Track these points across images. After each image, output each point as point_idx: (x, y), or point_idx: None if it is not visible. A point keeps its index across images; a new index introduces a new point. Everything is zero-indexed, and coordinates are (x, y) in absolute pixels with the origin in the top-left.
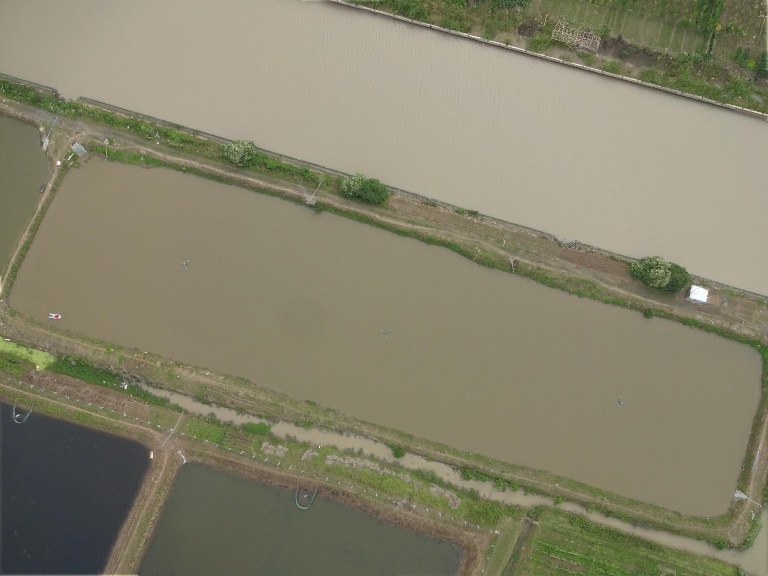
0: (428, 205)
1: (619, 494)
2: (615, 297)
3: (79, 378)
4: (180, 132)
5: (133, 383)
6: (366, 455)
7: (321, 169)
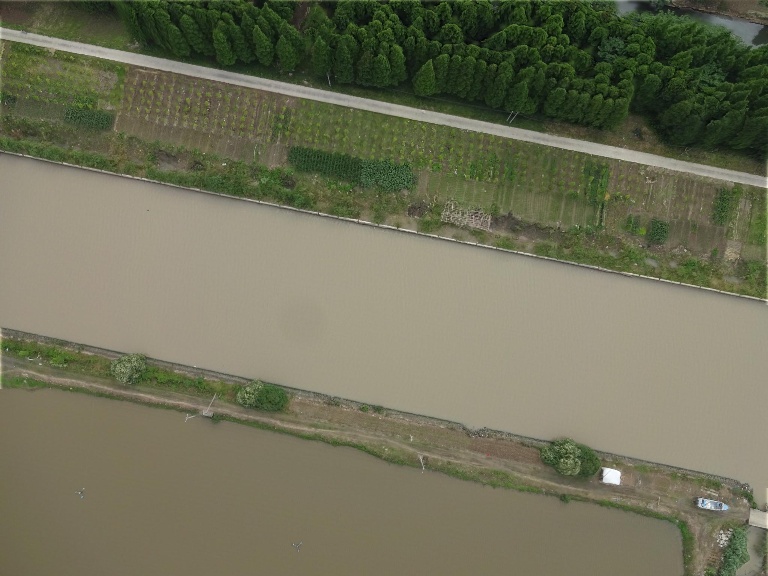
0: (330, 405)
1: None
2: (529, 485)
3: None
4: (63, 350)
5: None
6: None
7: (216, 375)
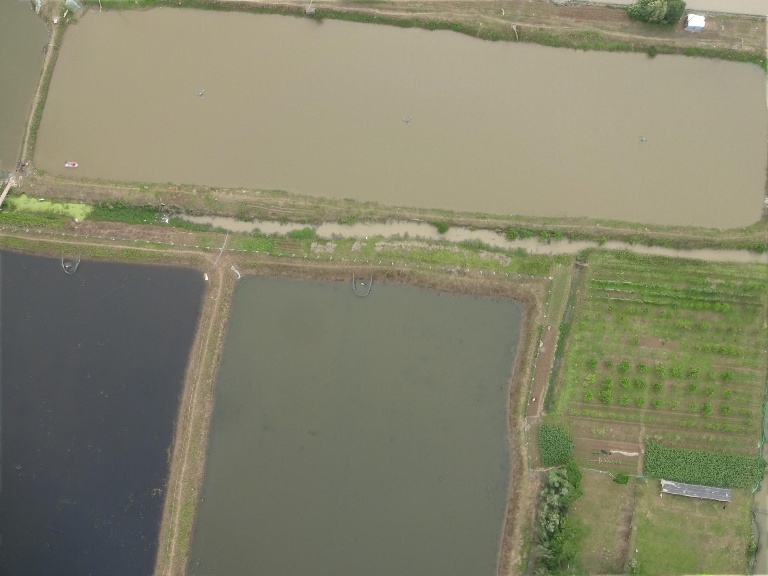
0: None
1: (658, 224)
2: (618, 42)
3: (119, 221)
4: None
5: (173, 216)
6: (412, 237)
7: None
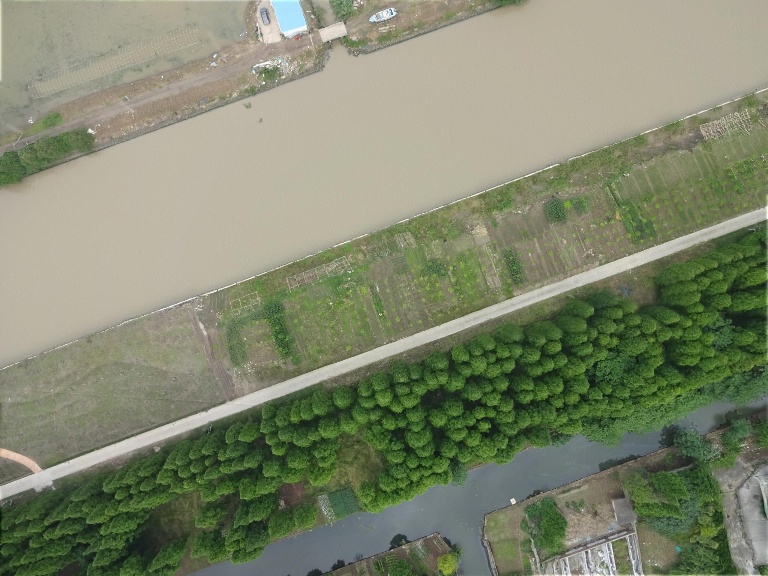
0: None
1: None
2: None
3: None
4: None
5: None
6: None
7: None
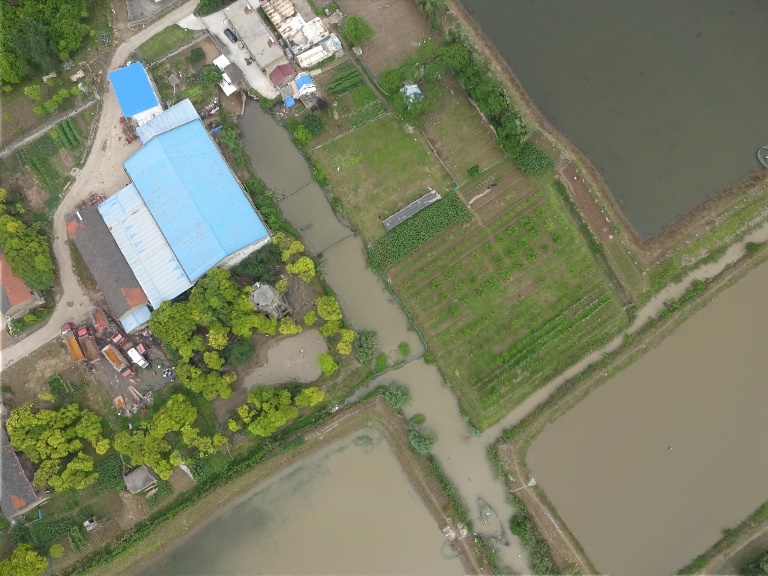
0: None
1: None
2: (767, 517)
3: None
4: None
5: None
6: (764, 223)
7: None
